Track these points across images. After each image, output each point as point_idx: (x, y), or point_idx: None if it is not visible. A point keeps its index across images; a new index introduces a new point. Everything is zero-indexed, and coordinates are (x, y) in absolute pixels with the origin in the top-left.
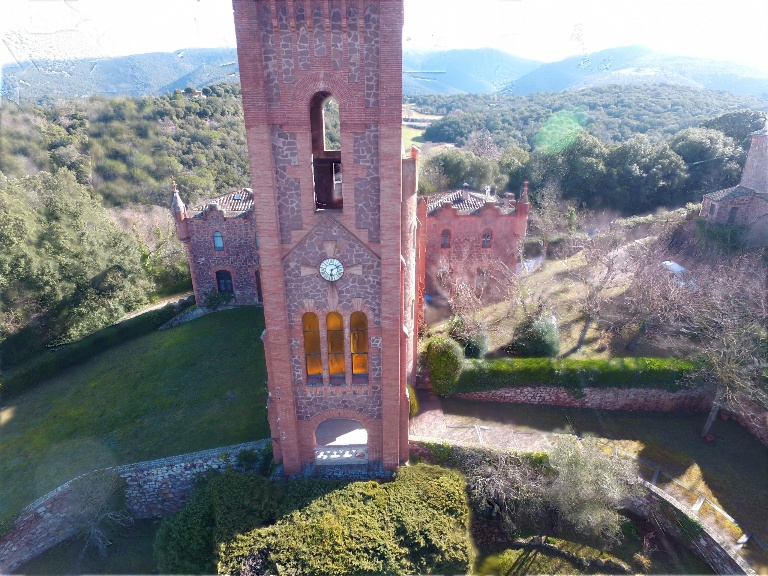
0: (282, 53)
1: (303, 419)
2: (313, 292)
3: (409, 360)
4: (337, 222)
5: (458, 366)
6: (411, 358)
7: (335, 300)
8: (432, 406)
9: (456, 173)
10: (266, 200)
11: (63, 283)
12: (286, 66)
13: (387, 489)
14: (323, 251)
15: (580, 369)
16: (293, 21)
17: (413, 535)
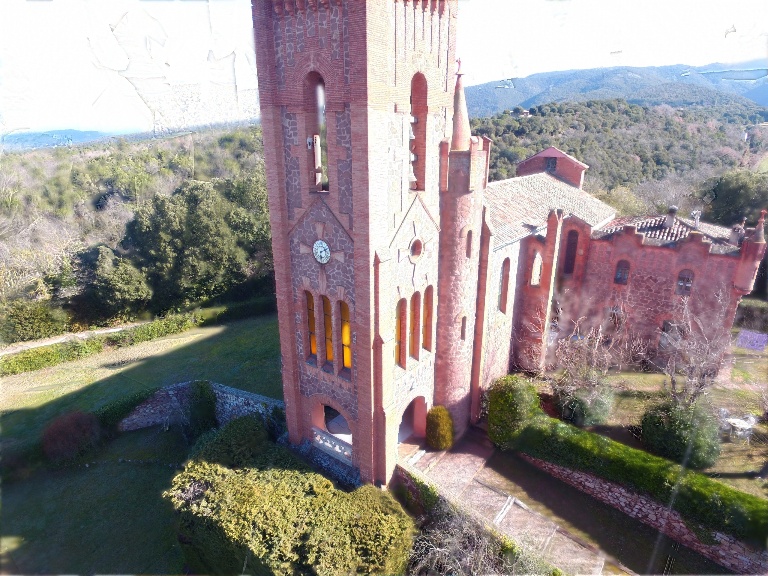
0: (286, 38)
1: (304, 394)
2: (309, 271)
3: (456, 386)
4: (324, 204)
5: (517, 416)
6: (460, 385)
7: (324, 283)
8: (479, 451)
9: (730, 200)
10: (273, 176)
11: None
12: (289, 50)
13: (335, 495)
14: (316, 232)
15: (713, 498)
16: (287, 5)
17: (309, 547)
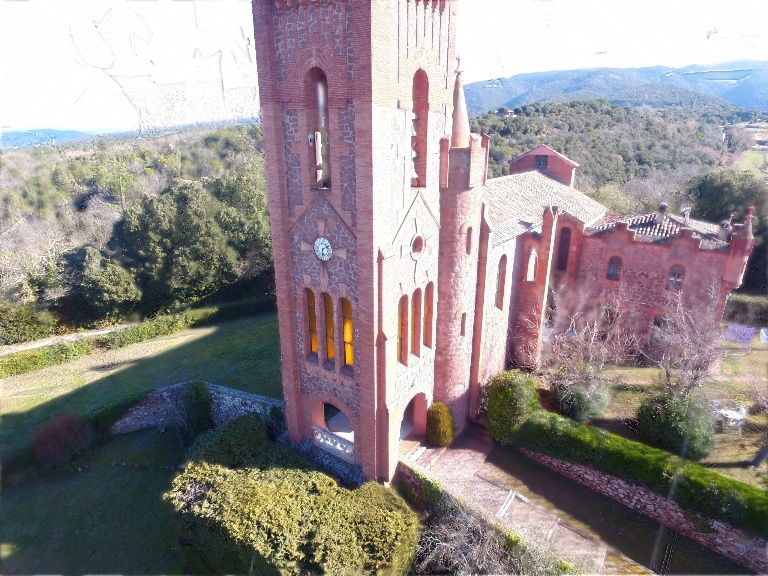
0: (287, 34)
1: (305, 393)
2: (311, 269)
3: (455, 382)
4: (326, 201)
5: (517, 411)
6: (460, 381)
7: (326, 281)
8: (479, 447)
9: (714, 198)
10: (273, 173)
11: None
12: (290, 46)
13: (338, 493)
14: (317, 229)
15: (710, 487)
16: (289, 1)
17: (315, 546)
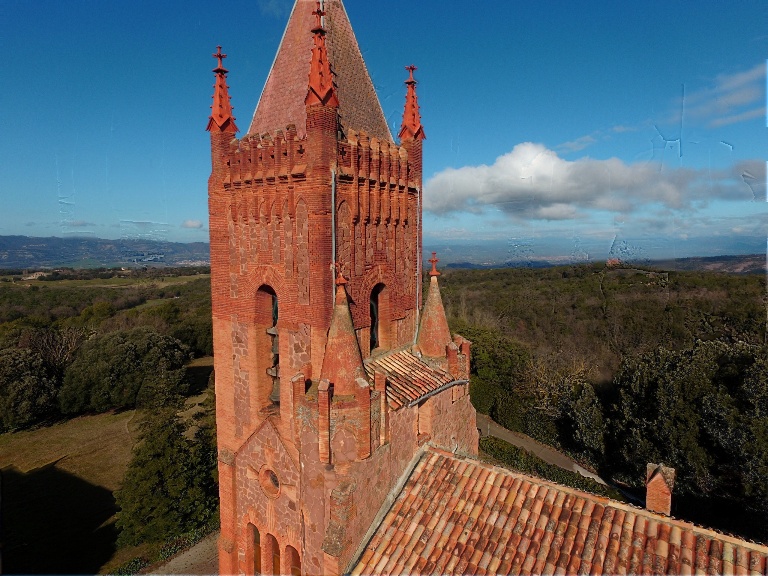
0: None
1: None
2: None
3: None
4: None
5: None
6: None
7: None
8: None
9: None
10: None
11: (762, 482)
12: None
13: None
14: None
15: None
16: None
17: None
